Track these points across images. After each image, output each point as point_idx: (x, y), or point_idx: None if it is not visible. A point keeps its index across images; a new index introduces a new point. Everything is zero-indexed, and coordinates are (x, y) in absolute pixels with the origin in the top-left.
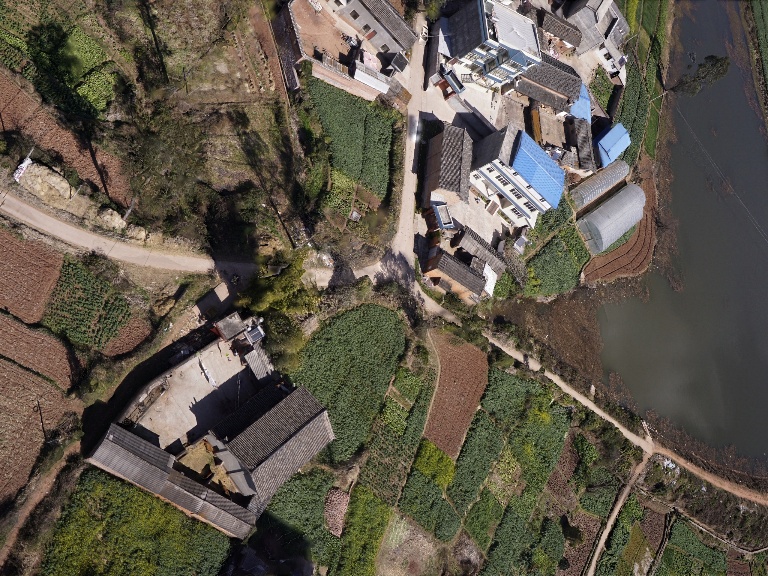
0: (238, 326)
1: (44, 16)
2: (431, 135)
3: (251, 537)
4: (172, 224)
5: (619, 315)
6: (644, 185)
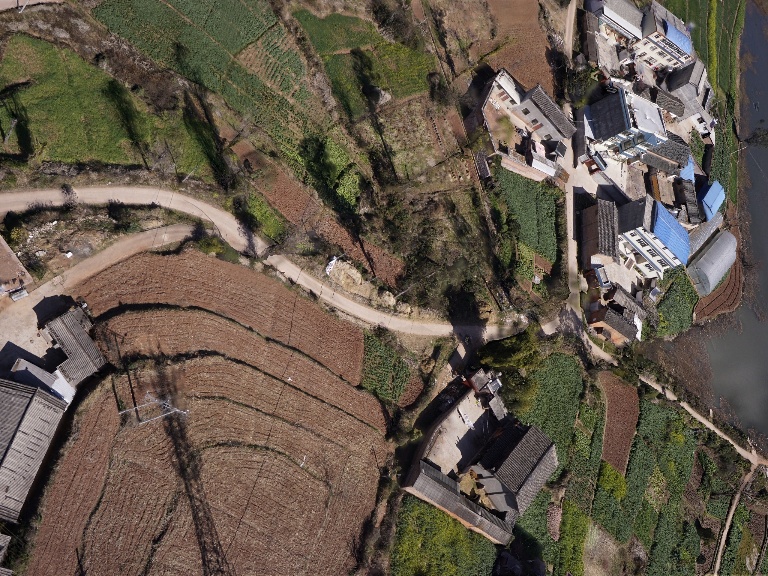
0: (483, 379)
1: (306, 131)
2: (583, 206)
3: (511, 543)
4: (423, 299)
5: (722, 347)
6: (731, 230)
